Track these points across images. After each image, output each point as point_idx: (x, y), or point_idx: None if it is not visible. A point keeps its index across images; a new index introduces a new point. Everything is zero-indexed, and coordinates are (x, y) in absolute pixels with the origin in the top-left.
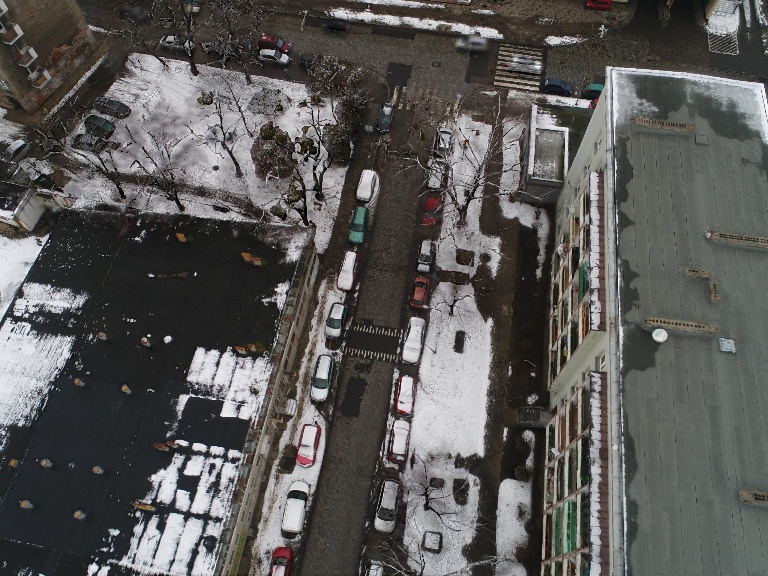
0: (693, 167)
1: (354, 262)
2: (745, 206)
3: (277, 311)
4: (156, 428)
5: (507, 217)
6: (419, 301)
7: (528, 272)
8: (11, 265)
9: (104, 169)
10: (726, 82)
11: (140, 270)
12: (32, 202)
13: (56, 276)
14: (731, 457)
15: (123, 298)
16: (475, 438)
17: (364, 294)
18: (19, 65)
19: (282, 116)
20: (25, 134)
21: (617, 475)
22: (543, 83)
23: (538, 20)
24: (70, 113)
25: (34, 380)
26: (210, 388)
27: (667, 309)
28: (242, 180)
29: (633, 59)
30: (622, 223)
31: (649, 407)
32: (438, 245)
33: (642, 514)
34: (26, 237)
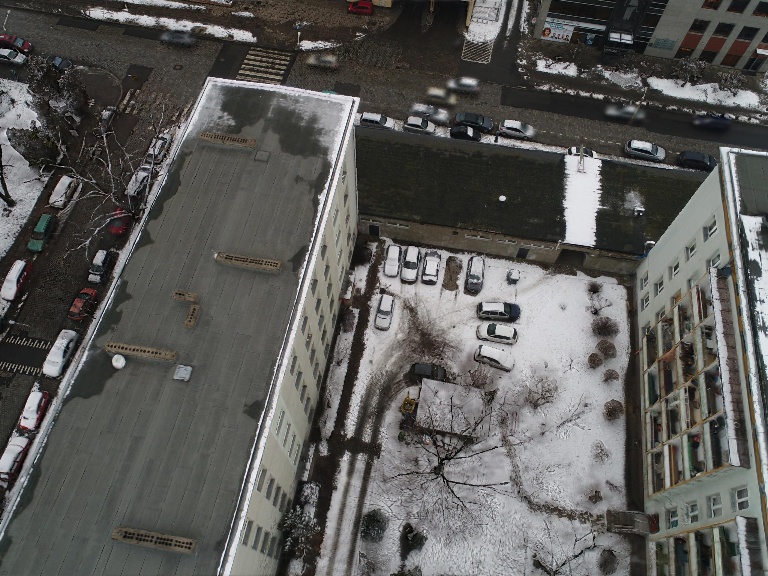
0: (240, 184)
1: (20, 271)
2: (275, 226)
3: None
4: None
5: None
6: (75, 313)
7: None
8: None
9: None
10: (318, 96)
11: None
12: None
13: None
14: (130, 491)
15: None
16: None
17: (28, 304)
18: None
19: (1, 118)
20: None
21: (10, 509)
22: None
23: None
24: None
25: None
26: None
27: (142, 333)
28: None
29: (381, 66)
30: (141, 242)
31: (74, 437)
32: None
33: (11, 551)
34: None
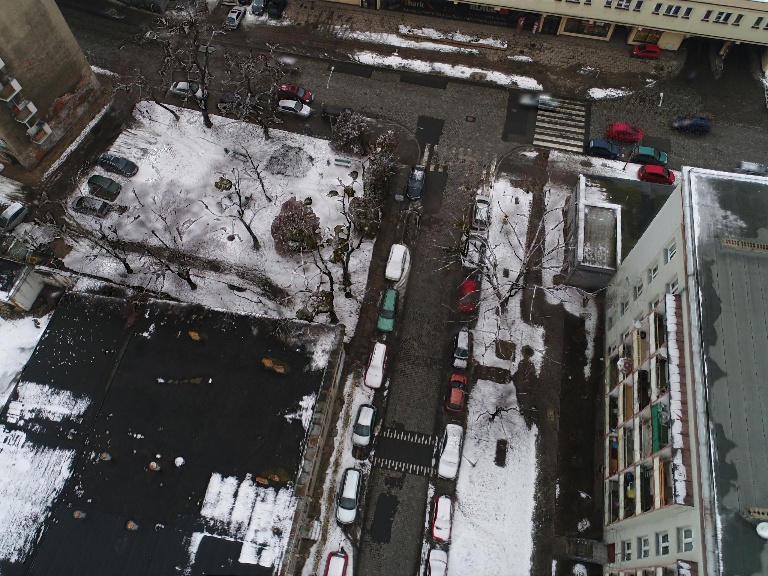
0: None
1: (384, 356)
2: None
3: (302, 430)
4: (166, 574)
5: (551, 303)
6: (456, 405)
7: (575, 370)
8: (6, 351)
9: (109, 237)
10: None
11: (148, 373)
12: (29, 280)
13: (55, 375)
14: None
15: (129, 408)
16: (520, 572)
17: (394, 392)
18: (17, 121)
19: (303, 178)
20: (23, 194)
21: None
22: (587, 144)
23: (580, 69)
24: (72, 170)
25: (29, 504)
26: (227, 525)
27: None
28: (260, 253)
29: (684, 116)
30: (712, 374)
31: None
32: (483, 355)
33: None
34: (22, 317)
